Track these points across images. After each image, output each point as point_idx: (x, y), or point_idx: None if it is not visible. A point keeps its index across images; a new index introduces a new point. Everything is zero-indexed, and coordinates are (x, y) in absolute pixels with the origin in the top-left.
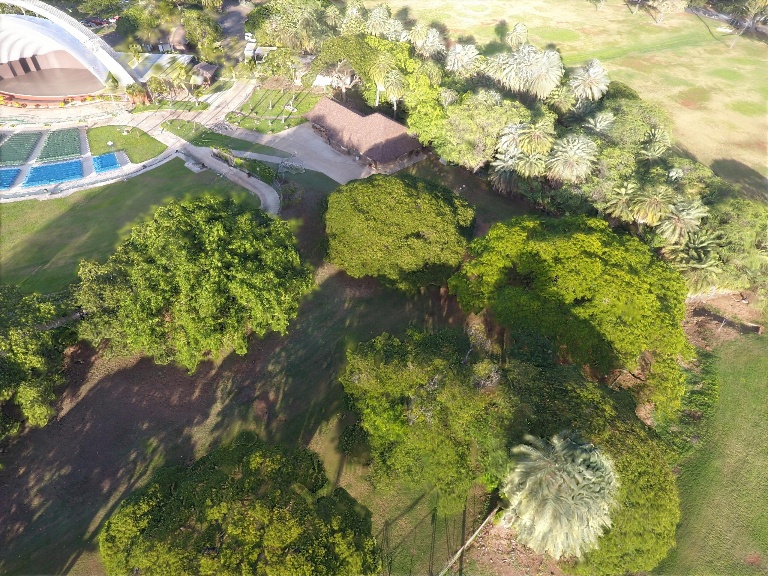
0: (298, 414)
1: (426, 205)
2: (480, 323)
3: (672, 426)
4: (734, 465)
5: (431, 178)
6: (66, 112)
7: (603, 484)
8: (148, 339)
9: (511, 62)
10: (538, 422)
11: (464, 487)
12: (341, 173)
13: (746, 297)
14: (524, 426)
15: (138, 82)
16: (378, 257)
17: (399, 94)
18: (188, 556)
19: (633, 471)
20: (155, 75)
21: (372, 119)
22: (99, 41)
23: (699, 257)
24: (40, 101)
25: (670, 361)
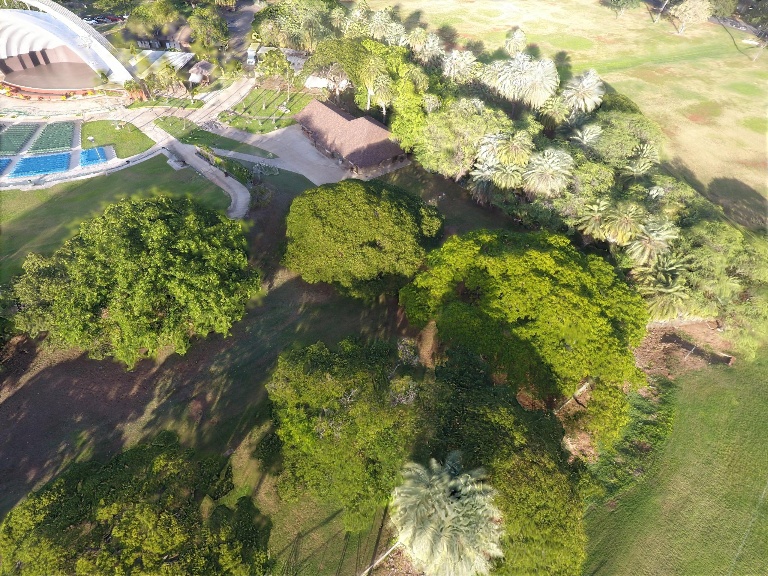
0: (232, 417)
1: (385, 213)
2: (411, 338)
3: (617, 457)
4: (675, 503)
5: (412, 185)
6: (66, 105)
7: (473, 518)
8: (79, 334)
9: (506, 70)
10: (440, 445)
11: (370, 506)
12: (321, 176)
13: (722, 325)
14: (426, 449)
15: (136, 78)
16: (332, 264)
17: (387, 99)
18: (66, 555)
19: (530, 504)
20: (154, 72)
21: (357, 123)
22: (99, 37)
23: (667, 281)
24: (44, 94)
25: (613, 389)
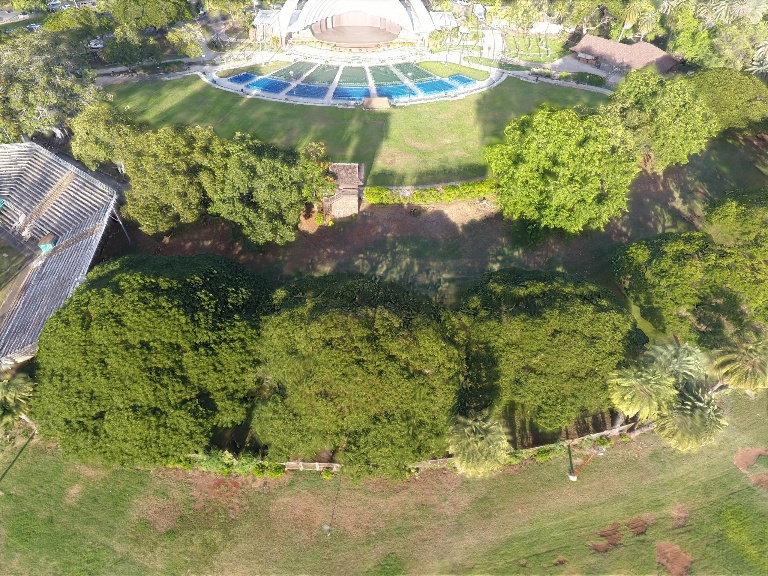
0: None
1: (758, 81)
2: None
3: None
4: None
5: None
6: (384, 54)
7: None
8: None
9: (723, 4)
10: None
11: None
12: None
13: None
14: None
15: None
16: (733, 114)
17: (652, 28)
18: None
19: None
20: (442, 25)
21: (639, 46)
22: None
23: None
24: None
25: None
